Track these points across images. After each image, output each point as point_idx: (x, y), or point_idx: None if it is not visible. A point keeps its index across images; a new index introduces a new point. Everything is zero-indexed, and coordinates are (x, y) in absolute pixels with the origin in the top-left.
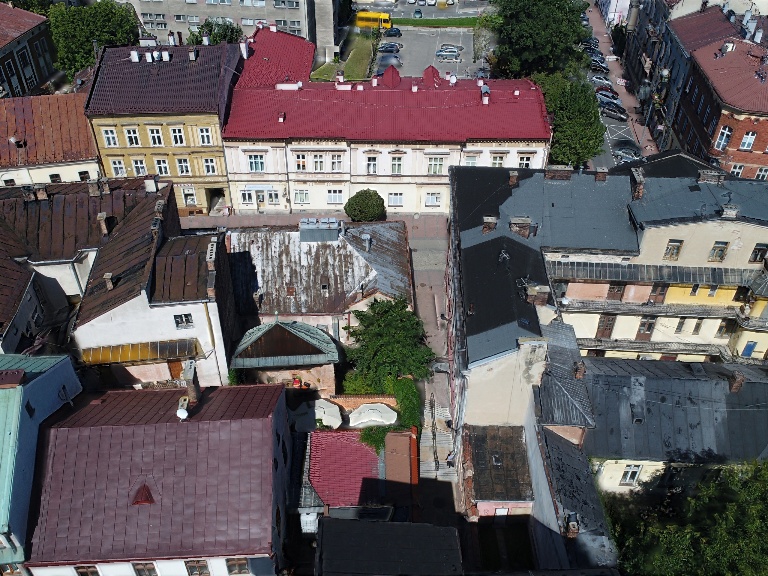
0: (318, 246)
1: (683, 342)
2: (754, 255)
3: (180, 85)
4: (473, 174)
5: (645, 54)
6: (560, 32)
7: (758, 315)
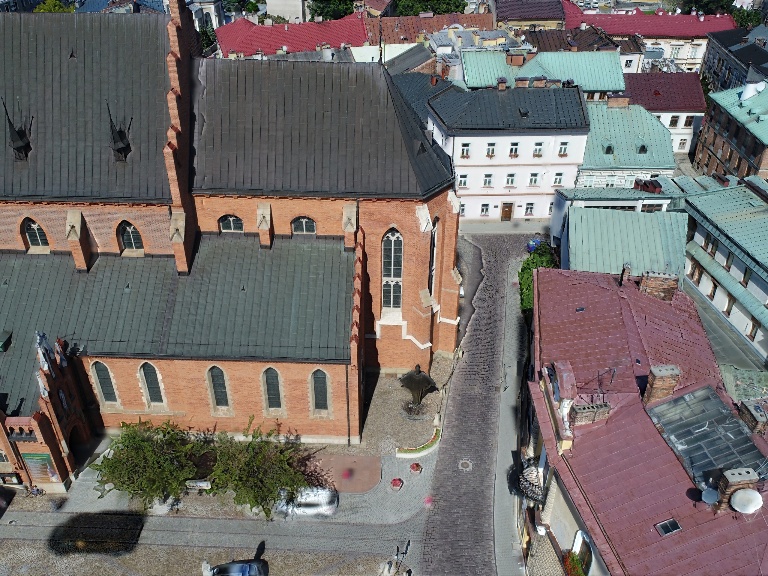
0: (652, 61)
1: None
2: None
3: (541, 7)
4: (723, 32)
5: None
6: None
7: None
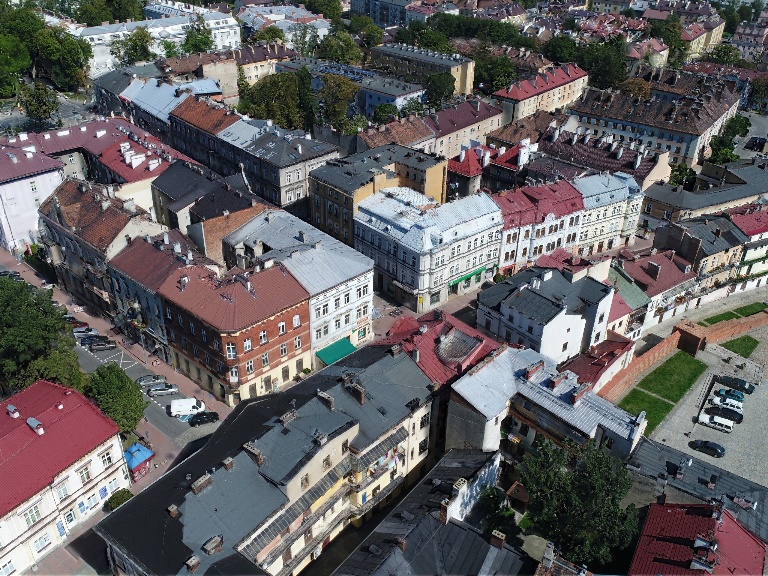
0: None
1: (329, 523)
2: (342, 449)
3: None
4: (126, 524)
5: (96, 287)
6: (45, 326)
7: (361, 479)
